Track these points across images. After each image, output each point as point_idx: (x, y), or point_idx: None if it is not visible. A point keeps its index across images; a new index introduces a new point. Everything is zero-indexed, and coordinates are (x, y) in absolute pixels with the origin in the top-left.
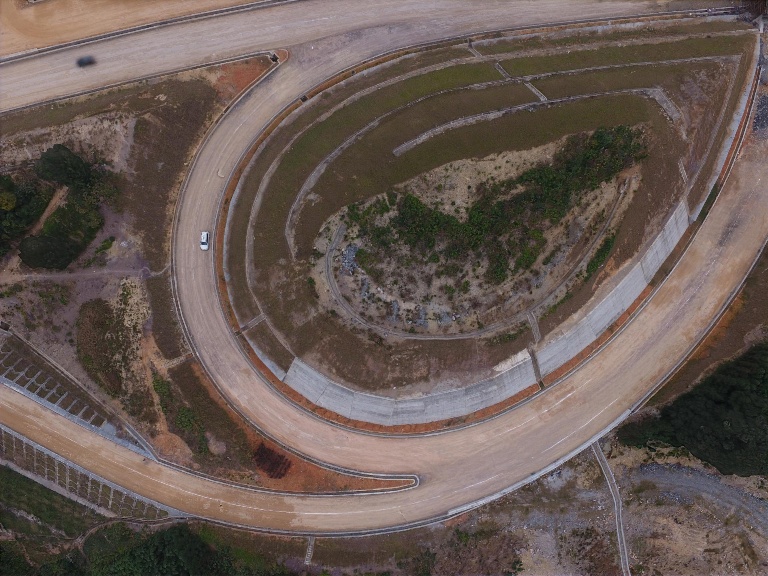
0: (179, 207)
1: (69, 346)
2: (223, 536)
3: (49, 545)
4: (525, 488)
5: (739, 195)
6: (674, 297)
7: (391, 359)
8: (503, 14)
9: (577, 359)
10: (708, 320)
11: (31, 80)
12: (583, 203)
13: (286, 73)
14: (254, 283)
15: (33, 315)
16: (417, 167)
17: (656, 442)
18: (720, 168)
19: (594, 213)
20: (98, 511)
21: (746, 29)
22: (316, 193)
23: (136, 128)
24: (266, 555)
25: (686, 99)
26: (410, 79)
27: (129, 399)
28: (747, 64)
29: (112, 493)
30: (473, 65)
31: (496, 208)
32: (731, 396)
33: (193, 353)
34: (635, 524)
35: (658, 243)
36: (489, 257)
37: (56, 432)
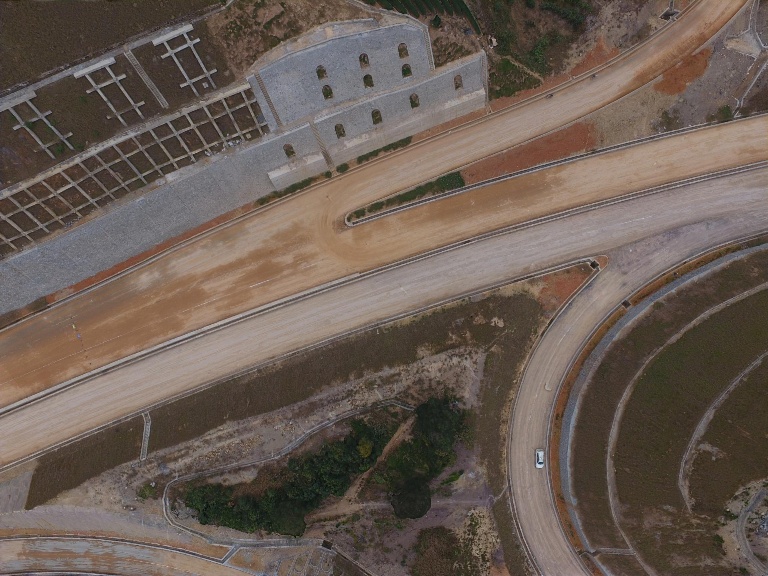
0: (511, 426)
1: (400, 566)
2: None
3: None
4: None
5: None
6: None
7: None
8: None
9: None
10: None
11: (353, 304)
12: None
13: (606, 279)
14: (620, 518)
15: (364, 538)
16: None
17: None
18: None
19: None
20: None
21: None
22: (714, 445)
23: (486, 363)
24: None
25: None
26: (761, 295)
27: None
28: None
29: None
30: None
31: None
32: None
33: (538, 575)
34: None
35: None
36: None
37: None
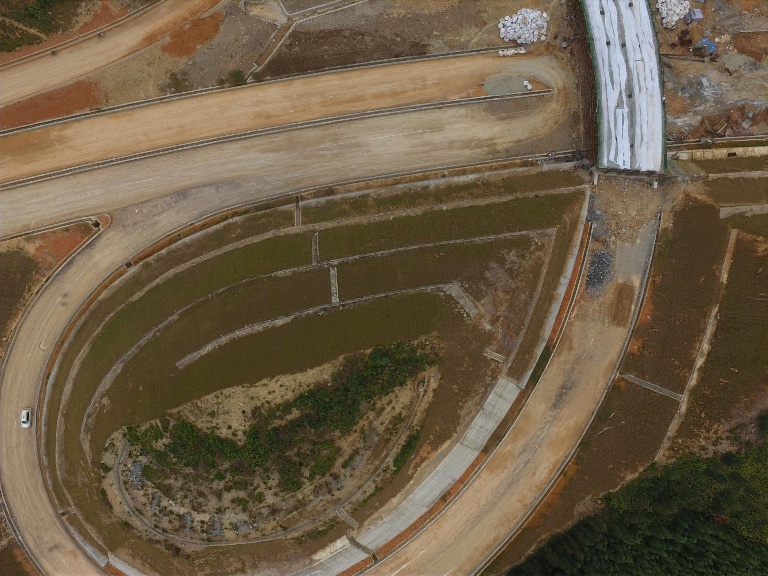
0: None
1: None
2: None
3: None
4: None
5: (572, 356)
6: (508, 463)
7: (195, 563)
8: (336, 167)
9: (410, 530)
10: (543, 485)
11: None
12: (378, 407)
13: (110, 238)
14: (64, 475)
15: None
16: (192, 390)
17: None
18: (548, 334)
19: (389, 417)
20: None
21: (575, 186)
22: (108, 398)
23: None
24: None
25: (491, 287)
26: (225, 254)
27: None
28: (572, 228)
29: None
30: (290, 237)
31: (272, 433)
32: None
33: (16, 537)
34: None
35: (480, 420)
36: (278, 471)
37: None
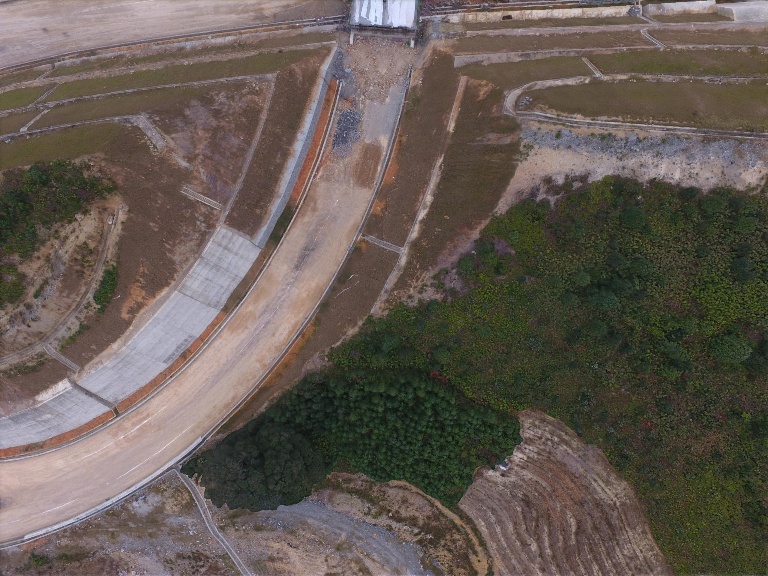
0: None
1: None
2: None
3: None
4: (109, 513)
5: (316, 217)
6: (249, 323)
7: None
8: (100, 31)
9: (150, 386)
10: (282, 346)
11: None
12: (62, 236)
13: None
14: None
15: None
16: None
17: None
18: (283, 190)
19: (73, 246)
20: None
21: (322, 42)
22: None
23: None
24: None
25: (190, 124)
26: None
27: None
28: (307, 80)
29: None
30: (28, 89)
31: None
32: (260, 428)
33: None
34: (247, 548)
35: (202, 270)
36: None
37: None
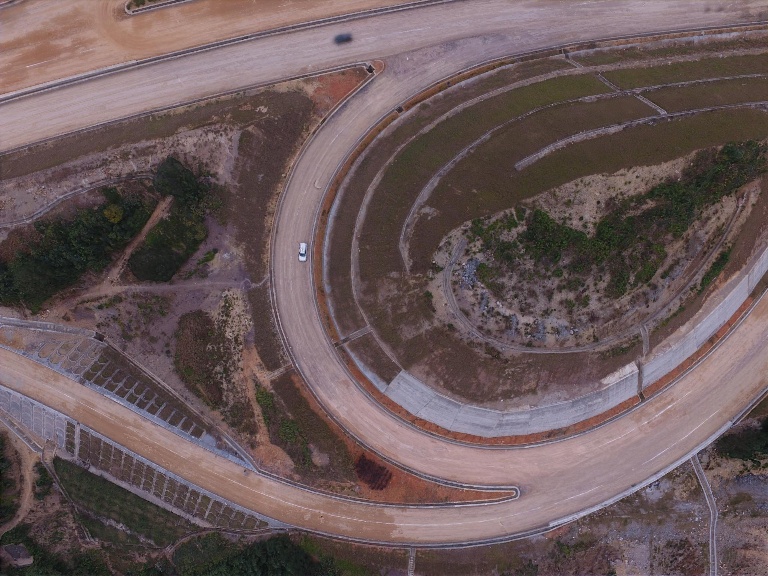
0: (277, 218)
1: (166, 357)
2: (325, 547)
3: (135, 554)
4: (624, 500)
5: None
6: None
7: (505, 372)
8: (597, 24)
9: (677, 371)
10: None
11: (129, 92)
12: (703, 217)
13: (382, 84)
14: (360, 295)
15: (130, 326)
16: (544, 182)
17: (754, 454)
18: None
19: (714, 227)
20: (193, 521)
21: None
22: (432, 207)
23: (241, 140)
24: (369, 566)
25: None
26: (513, 91)
27: (230, 410)
28: None
29: (211, 504)
30: (576, 77)
31: (625, 223)
32: None
33: (293, 364)
34: (728, 535)
35: (765, 255)
36: (612, 271)
37: (156, 443)
